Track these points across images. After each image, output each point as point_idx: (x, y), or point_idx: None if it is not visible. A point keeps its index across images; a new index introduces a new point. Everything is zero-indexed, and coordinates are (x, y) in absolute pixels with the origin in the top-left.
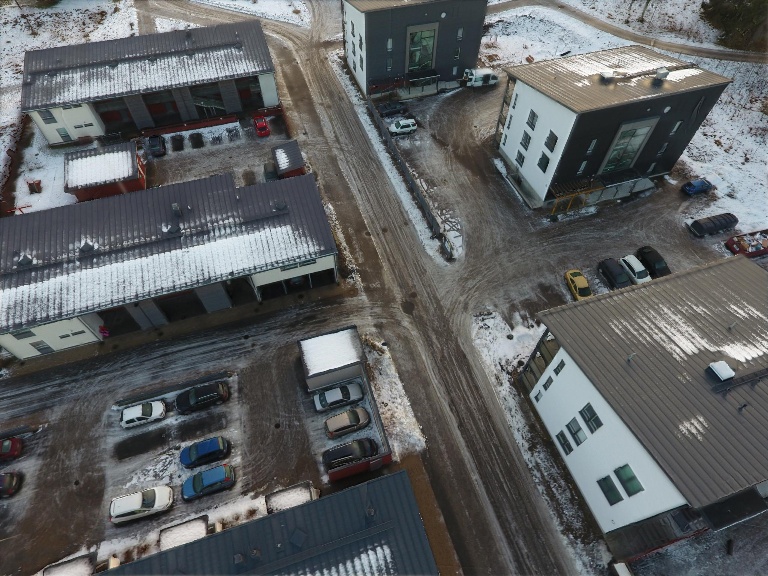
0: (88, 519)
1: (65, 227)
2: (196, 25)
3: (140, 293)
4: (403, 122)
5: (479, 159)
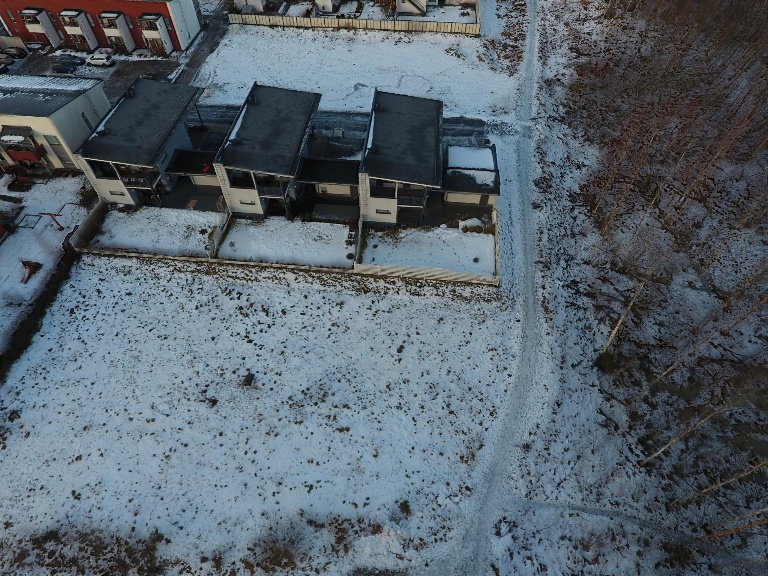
0: (124, 67)
1: (4, 104)
2: None
3: (8, 75)
4: None
5: None
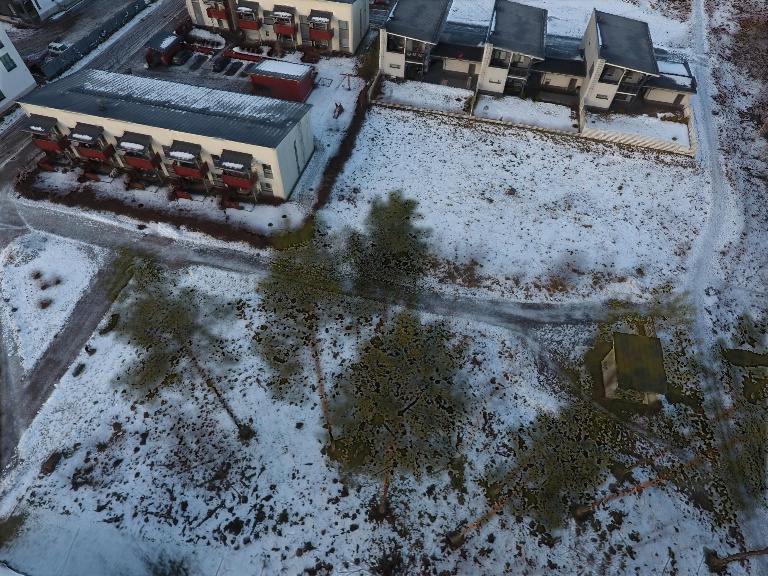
0: None
1: None
2: (4, 303)
3: None
4: (59, 44)
5: (59, 23)
